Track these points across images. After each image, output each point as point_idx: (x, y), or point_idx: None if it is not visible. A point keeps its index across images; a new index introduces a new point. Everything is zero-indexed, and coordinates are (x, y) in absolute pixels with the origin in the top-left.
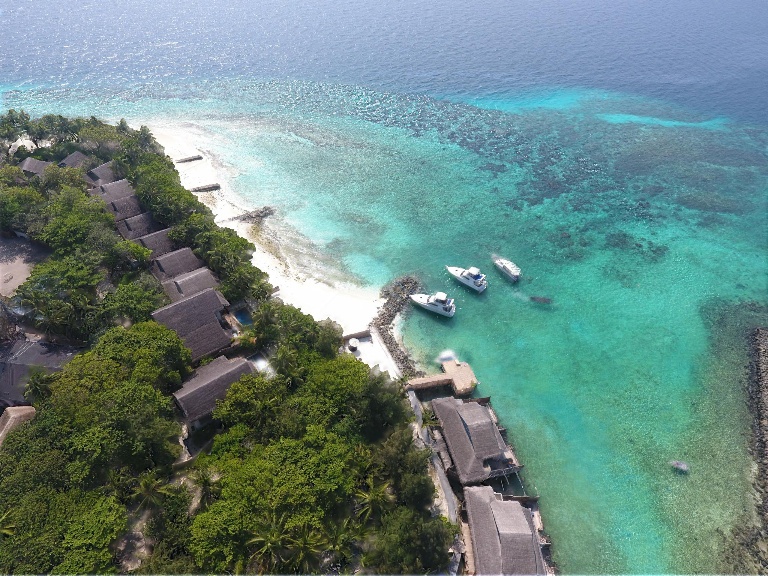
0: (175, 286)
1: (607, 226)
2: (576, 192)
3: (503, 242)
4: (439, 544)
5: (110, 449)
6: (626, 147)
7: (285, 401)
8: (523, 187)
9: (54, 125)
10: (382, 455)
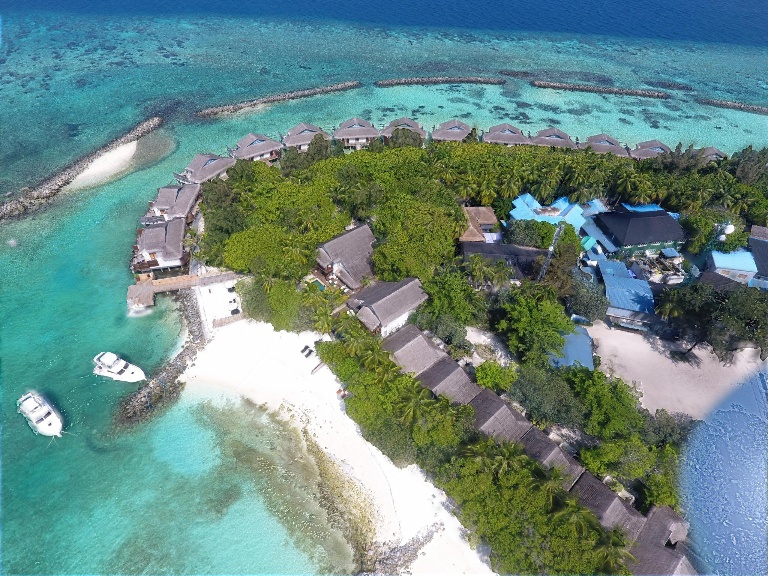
0: None
1: None
2: None
3: None
4: None
5: None
6: None
7: None
8: None
9: None
10: None
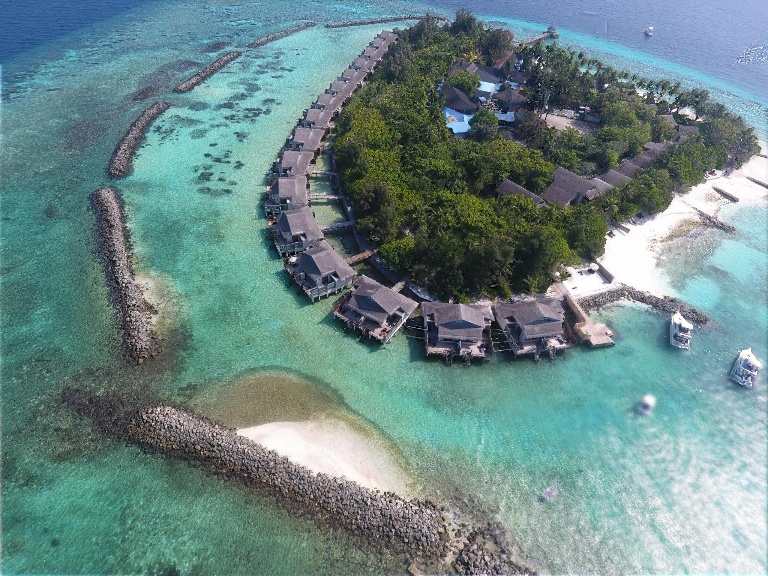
0: None
1: None
2: None
3: None
4: (450, 280)
5: (472, 163)
6: None
7: None
8: None
9: None
10: None
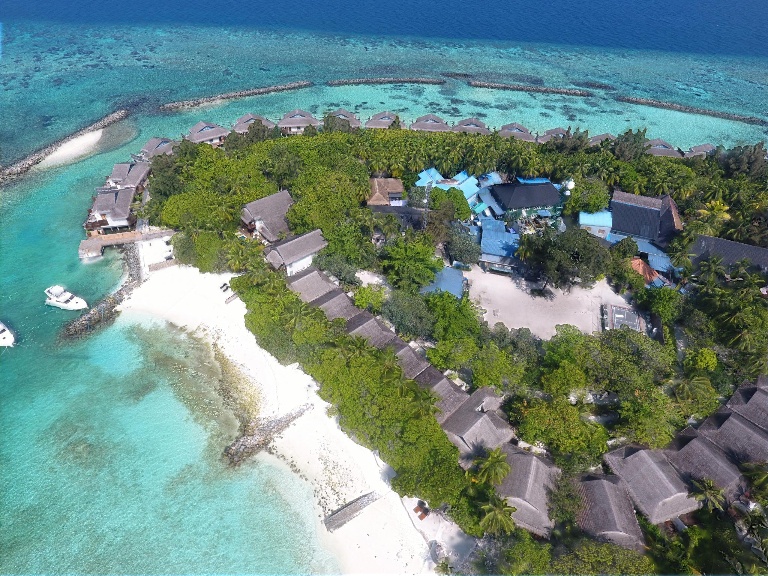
0: None
1: None
2: None
3: None
4: None
5: None
6: None
7: None
8: None
9: None
10: None
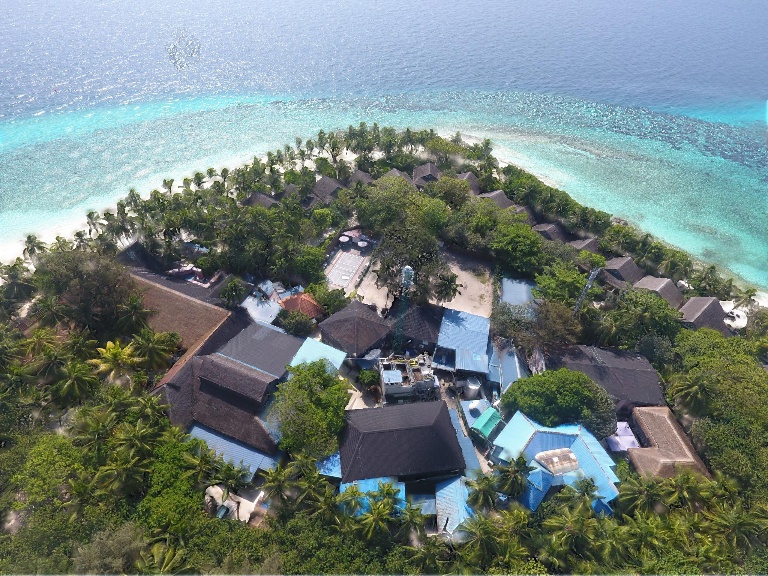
0: None
1: None
2: None
3: None
4: None
5: None
6: None
7: None
8: None
9: (395, 137)
10: None
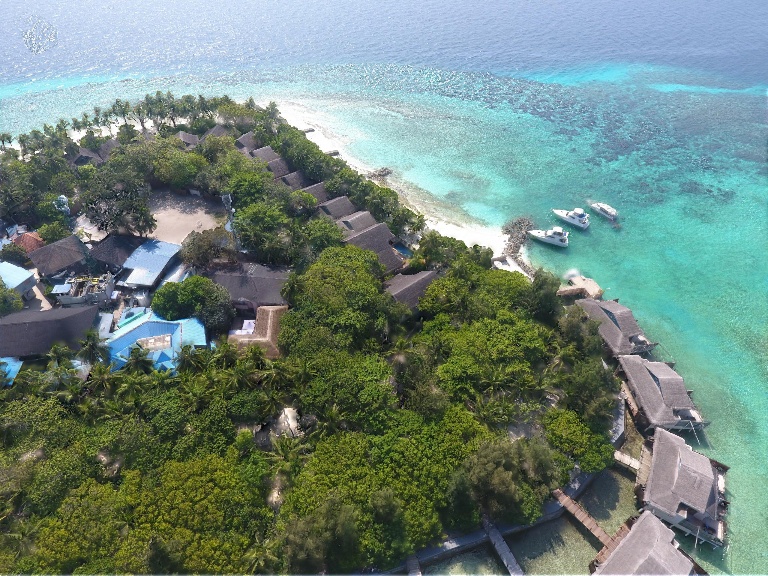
0: (344, 225)
1: (678, 177)
2: (645, 150)
3: (592, 191)
4: (614, 387)
5: (362, 325)
6: (681, 112)
7: (469, 298)
8: (597, 147)
9: (193, 104)
10: (563, 326)
